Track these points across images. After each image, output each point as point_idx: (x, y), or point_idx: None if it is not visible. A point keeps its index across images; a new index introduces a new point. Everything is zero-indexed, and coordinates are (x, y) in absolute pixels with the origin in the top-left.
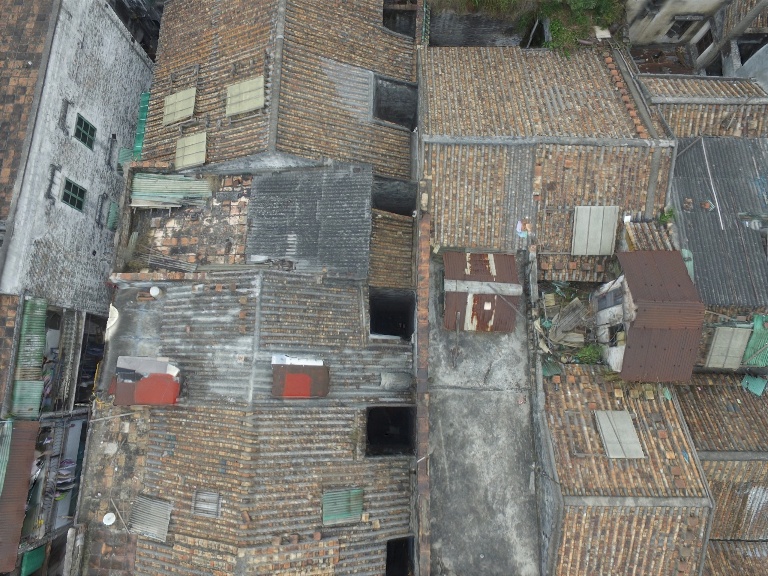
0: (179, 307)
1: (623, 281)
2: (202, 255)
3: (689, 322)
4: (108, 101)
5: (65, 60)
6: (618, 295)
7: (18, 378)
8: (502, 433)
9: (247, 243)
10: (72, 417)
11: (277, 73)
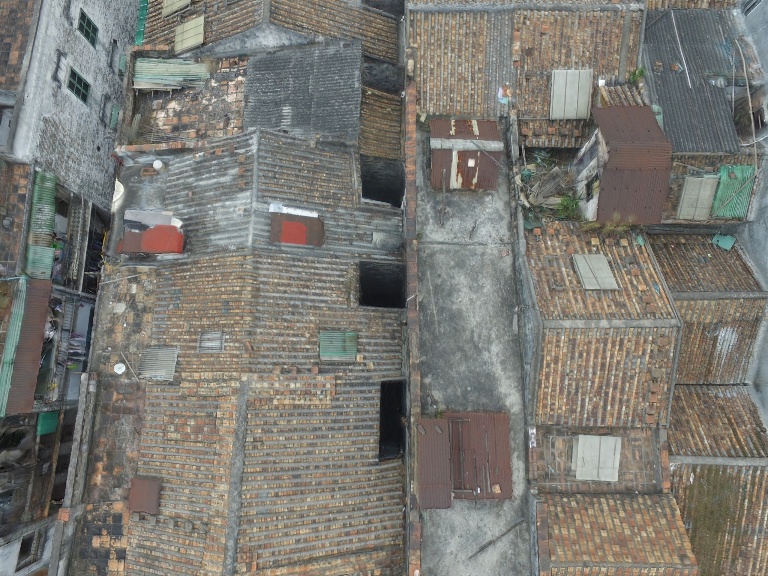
0: (181, 176)
1: (597, 133)
2: (202, 130)
3: (658, 162)
4: (109, 6)
5: None
6: (594, 151)
7: (30, 243)
8: (487, 282)
9: (244, 116)
10: (81, 298)
11: None
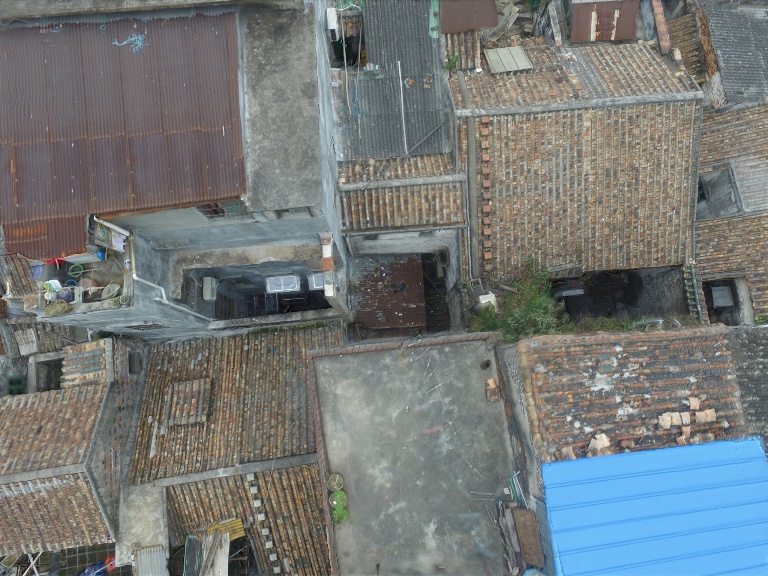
0: None
1: None
2: None
3: None
4: None
5: None
6: None
7: None
8: None
9: None
10: None
11: None
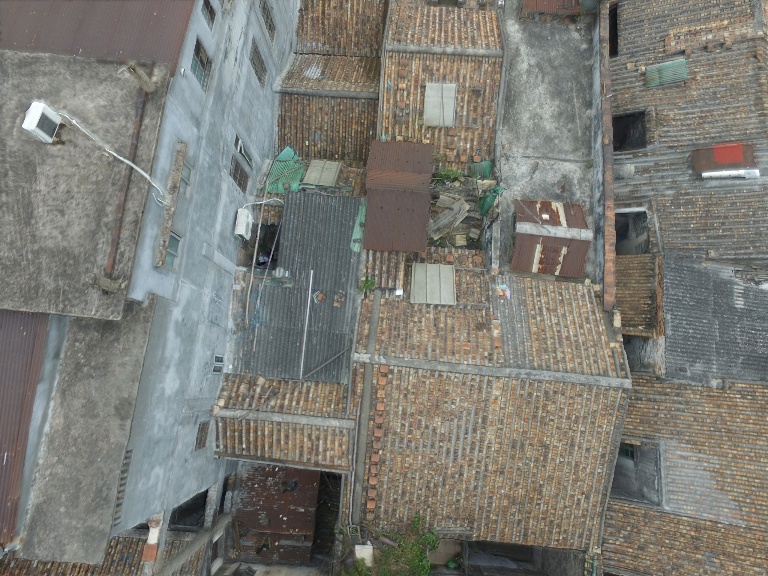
0: None
1: None
2: None
3: (381, 175)
4: None
5: None
6: None
7: None
8: (526, 123)
9: None
10: None
11: None
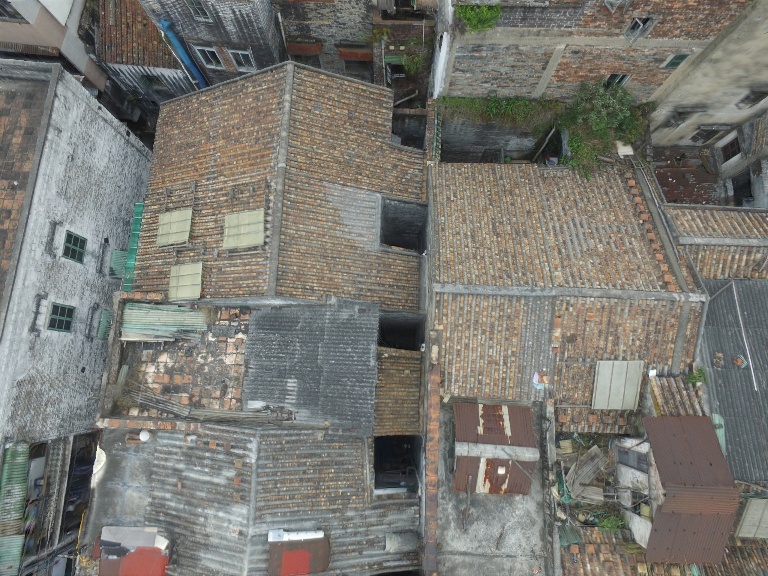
0: (170, 457)
1: (649, 451)
2: (196, 397)
3: (722, 508)
4: (100, 206)
5: (53, 179)
6: (642, 460)
7: None
8: None
9: (244, 387)
10: (57, 552)
11: (278, 207)
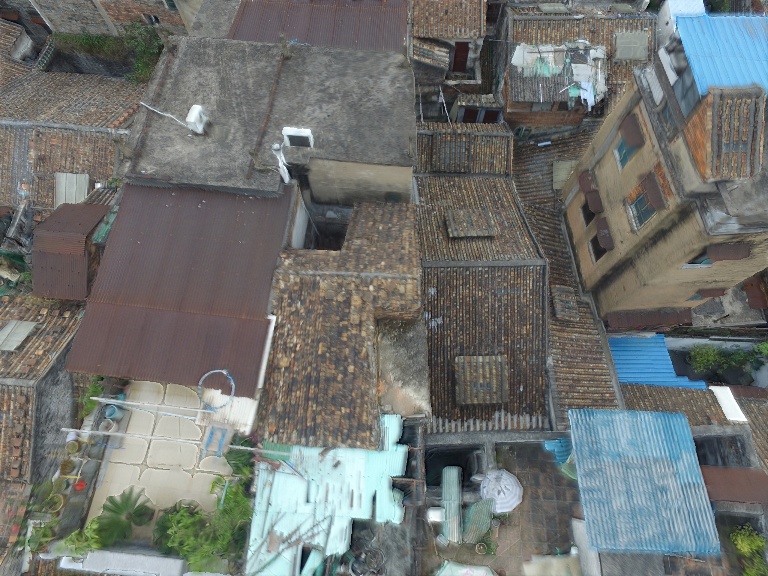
0: None
1: None
2: None
3: (72, 249)
4: None
5: None
6: None
7: None
8: None
9: None
10: None
11: None
